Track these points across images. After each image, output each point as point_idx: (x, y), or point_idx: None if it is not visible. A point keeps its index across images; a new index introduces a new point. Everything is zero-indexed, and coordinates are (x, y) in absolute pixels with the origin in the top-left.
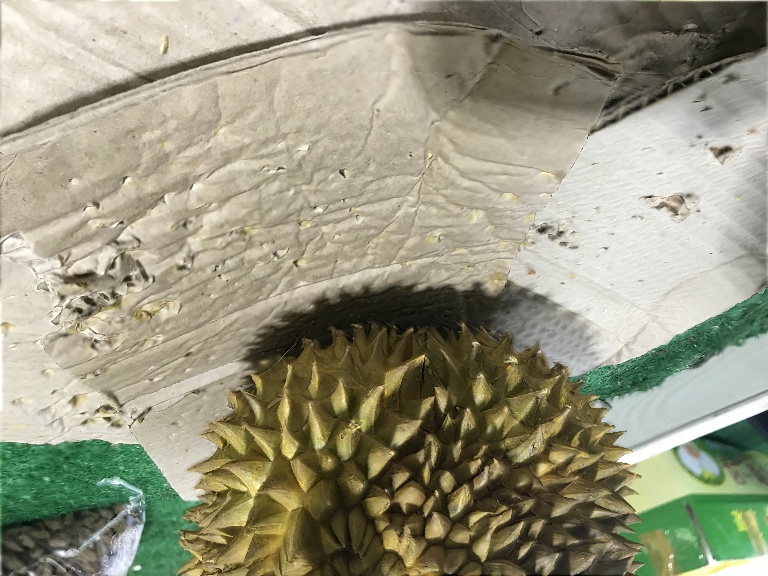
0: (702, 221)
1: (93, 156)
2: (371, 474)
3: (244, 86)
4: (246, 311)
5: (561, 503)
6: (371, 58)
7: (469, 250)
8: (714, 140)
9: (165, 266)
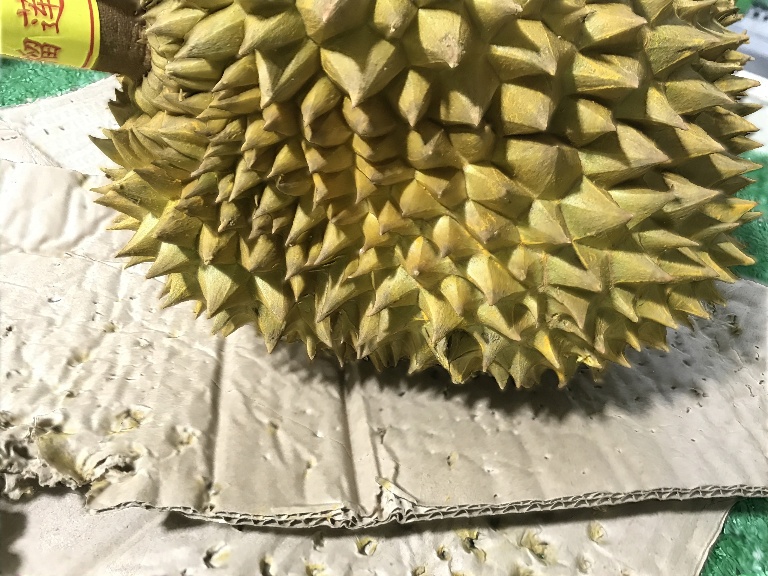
0: None
1: None
2: None
3: None
4: None
5: None
6: None
7: None
8: (109, 122)
9: None
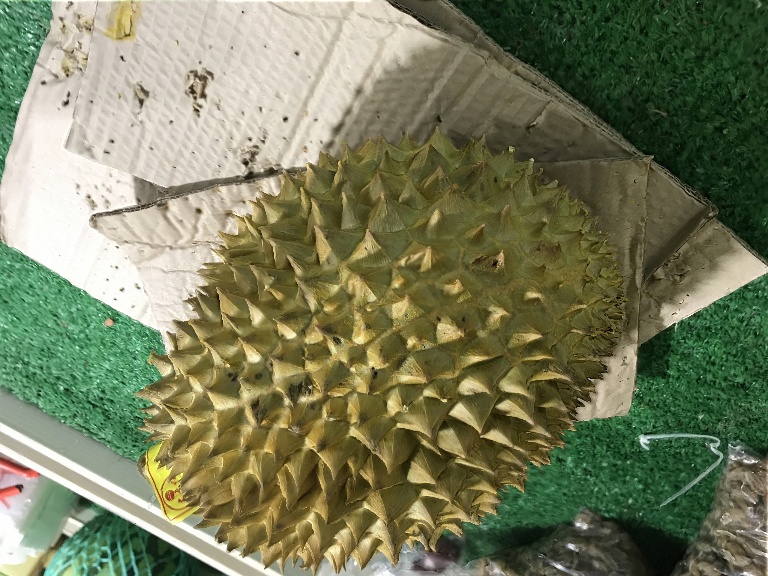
0: (209, 51)
1: None
2: None
3: (158, 314)
4: None
5: None
6: None
7: None
8: (133, 113)
9: None
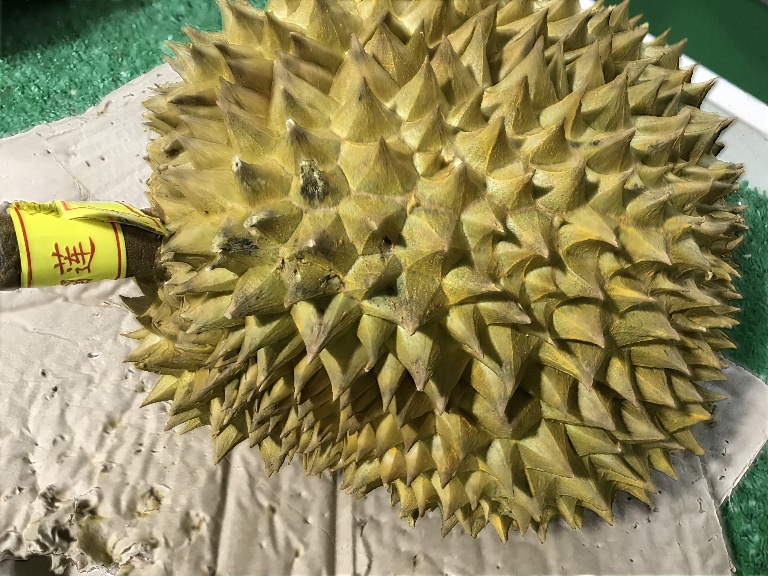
0: None
1: None
2: None
3: None
4: (239, 449)
5: None
6: None
7: None
8: None
9: None
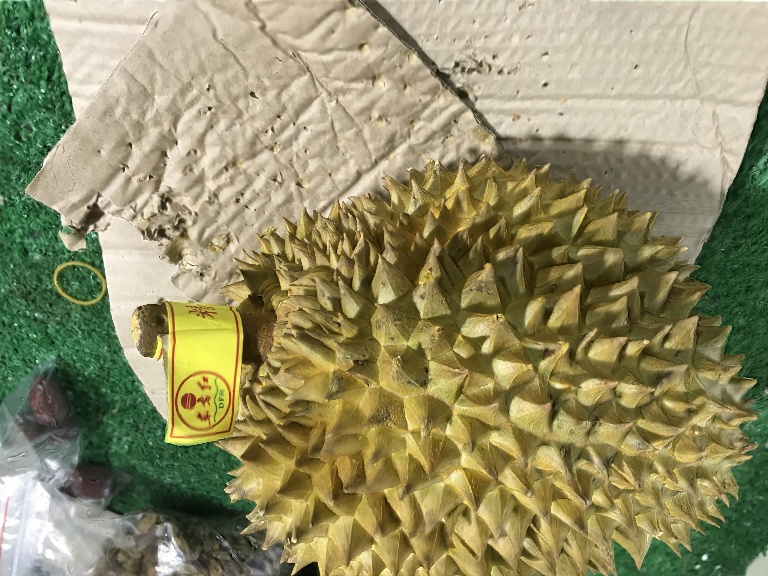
0: None
1: (99, 133)
2: (289, 258)
3: (137, 62)
4: None
5: (426, 222)
6: (186, 12)
7: (423, 120)
8: None
9: (200, 204)
